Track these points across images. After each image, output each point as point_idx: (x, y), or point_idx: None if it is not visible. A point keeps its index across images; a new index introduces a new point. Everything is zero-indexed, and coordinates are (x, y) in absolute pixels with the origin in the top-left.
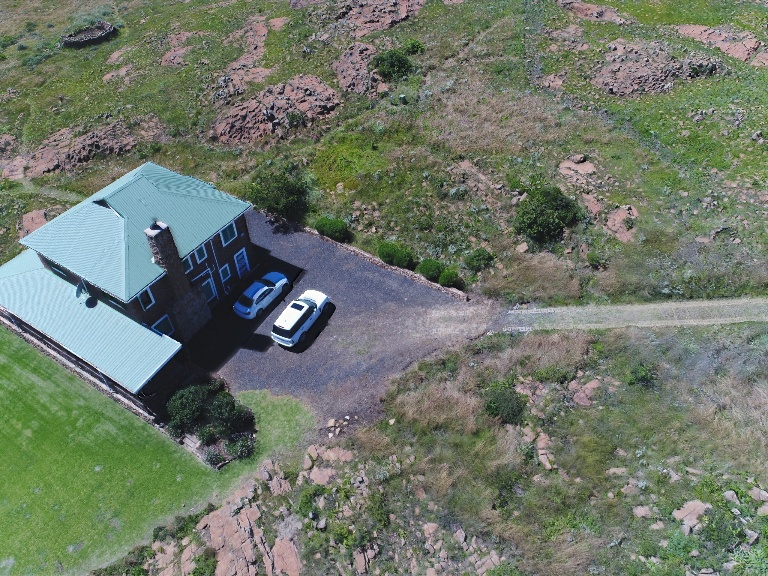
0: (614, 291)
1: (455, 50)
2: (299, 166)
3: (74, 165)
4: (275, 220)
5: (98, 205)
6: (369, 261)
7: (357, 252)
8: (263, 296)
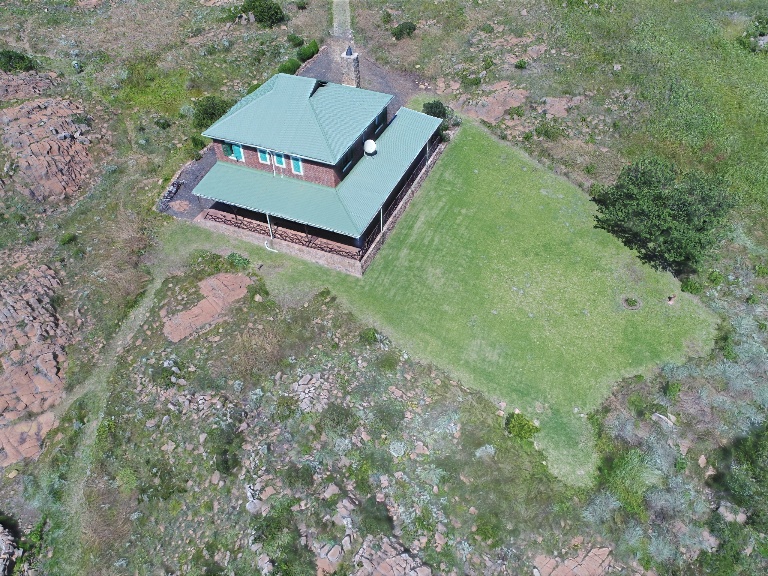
0: (326, 2)
1: None
2: None
3: (62, 331)
4: None
5: (312, 96)
6: None
7: None
8: None
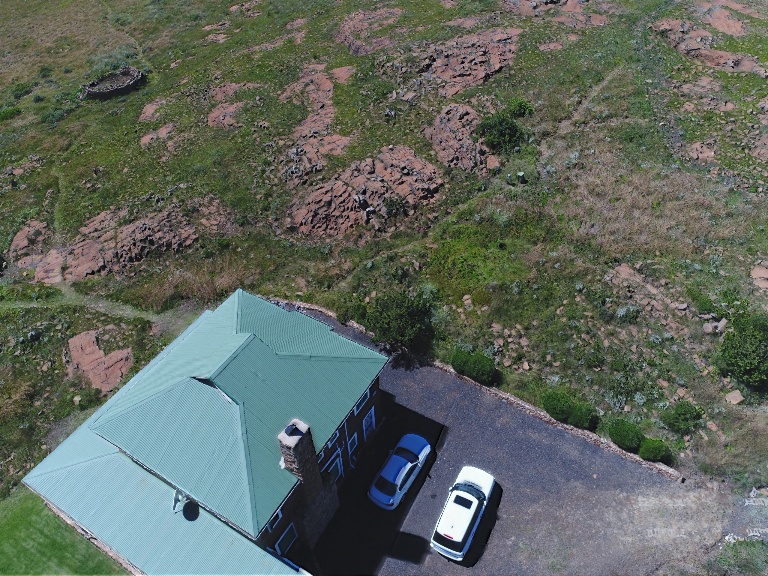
0: None
1: (569, 110)
2: (410, 271)
3: (124, 266)
4: (391, 348)
5: (198, 382)
6: (529, 413)
7: (512, 401)
8: (405, 475)
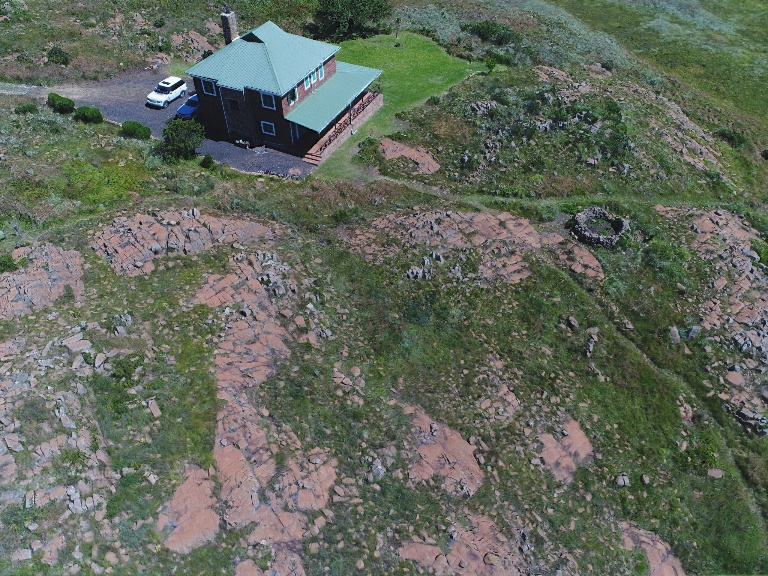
0: None
1: None
2: None
3: None
4: None
5: None
6: None
7: None
8: None
